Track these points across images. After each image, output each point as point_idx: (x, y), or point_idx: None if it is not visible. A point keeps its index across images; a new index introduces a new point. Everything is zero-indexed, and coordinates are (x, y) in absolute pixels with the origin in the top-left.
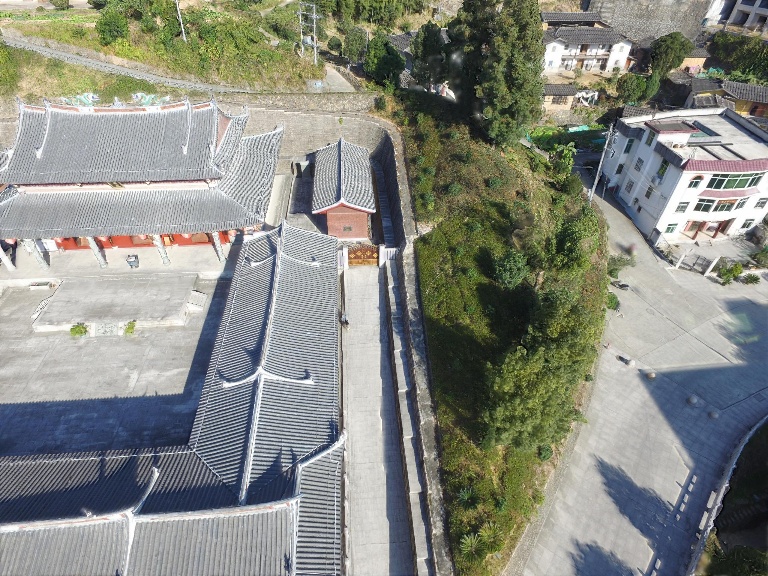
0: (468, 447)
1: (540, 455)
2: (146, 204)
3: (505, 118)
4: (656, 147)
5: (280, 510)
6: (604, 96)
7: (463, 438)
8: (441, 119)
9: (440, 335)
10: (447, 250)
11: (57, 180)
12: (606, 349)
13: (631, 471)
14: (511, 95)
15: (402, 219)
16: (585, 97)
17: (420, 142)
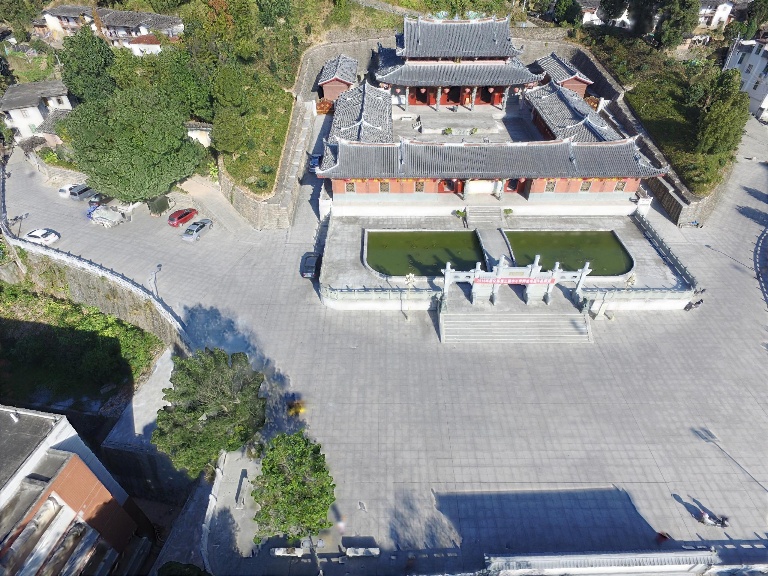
0: (687, 154)
1: (720, 162)
2: (473, 71)
3: (673, 29)
4: (763, 54)
5: (629, 143)
6: (714, 39)
7: (682, 153)
8: (622, 37)
9: (656, 124)
10: (648, 93)
11: (433, 55)
12: (737, 155)
13: (761, 190)
14: (683, 11)
15: (611, 85)
16: (700, 40)
17: (609, 51)
